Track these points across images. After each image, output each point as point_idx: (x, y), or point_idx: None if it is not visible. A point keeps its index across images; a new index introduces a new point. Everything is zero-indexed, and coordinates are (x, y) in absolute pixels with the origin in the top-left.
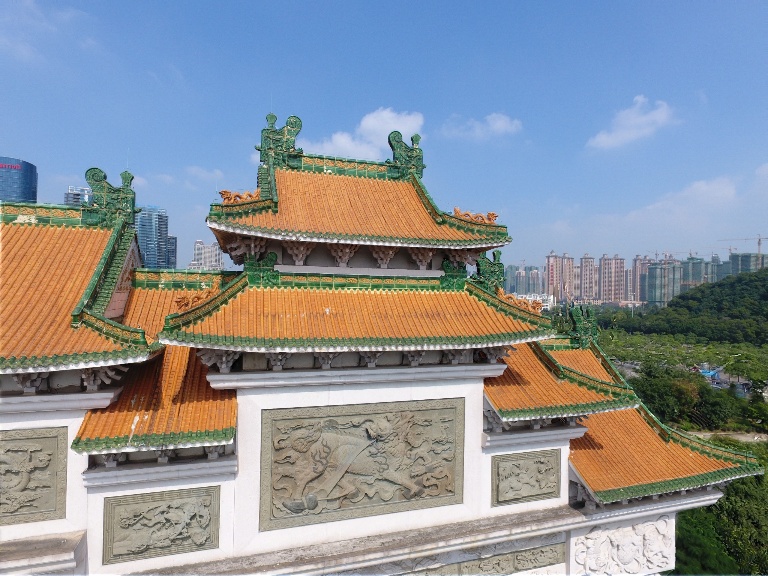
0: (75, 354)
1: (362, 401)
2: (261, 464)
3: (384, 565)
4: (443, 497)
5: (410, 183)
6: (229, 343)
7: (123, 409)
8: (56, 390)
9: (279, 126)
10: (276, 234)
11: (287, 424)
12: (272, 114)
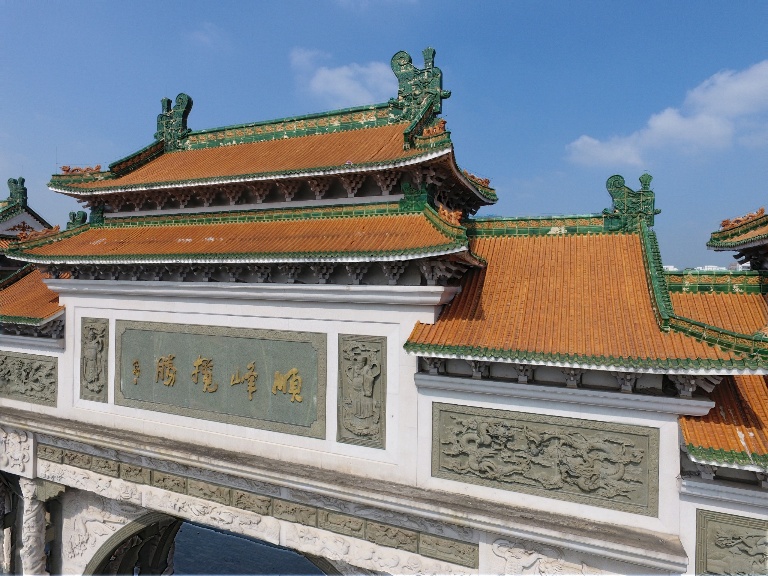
0: (690, 359)
1: None
2: None
3: None
4: None
5: None
6: None
7: (716, 420)
8: (649, 391)
9: None
10: None
11: None
12: None
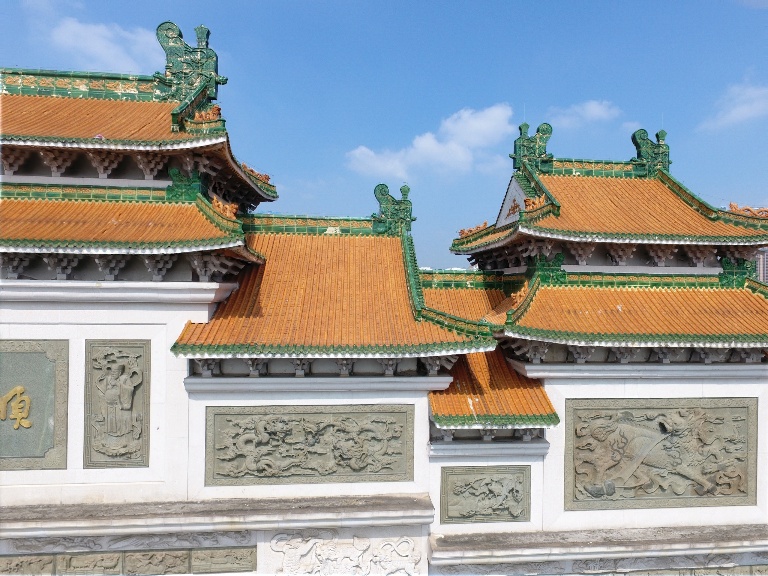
0: (436, 343)
1: (655, 396)
2: (565, 449)
3: (678, 557)
4: (735, 497)
5: (657, 180)
6: (557, 336)
7: (454, 392)
8: None
9: (531, 134)
10: (575, 236)
11: (587, 413)
12: (525, 123)
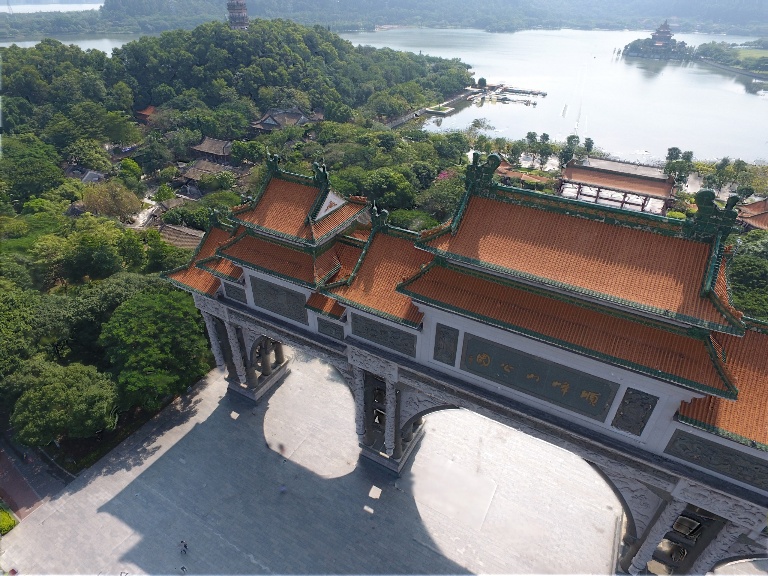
0: None
1: None
2: None
3: None
4: None
5: None
6: None
7: None
8: None
9: (322, 169)
10: None
11: None
12: None
